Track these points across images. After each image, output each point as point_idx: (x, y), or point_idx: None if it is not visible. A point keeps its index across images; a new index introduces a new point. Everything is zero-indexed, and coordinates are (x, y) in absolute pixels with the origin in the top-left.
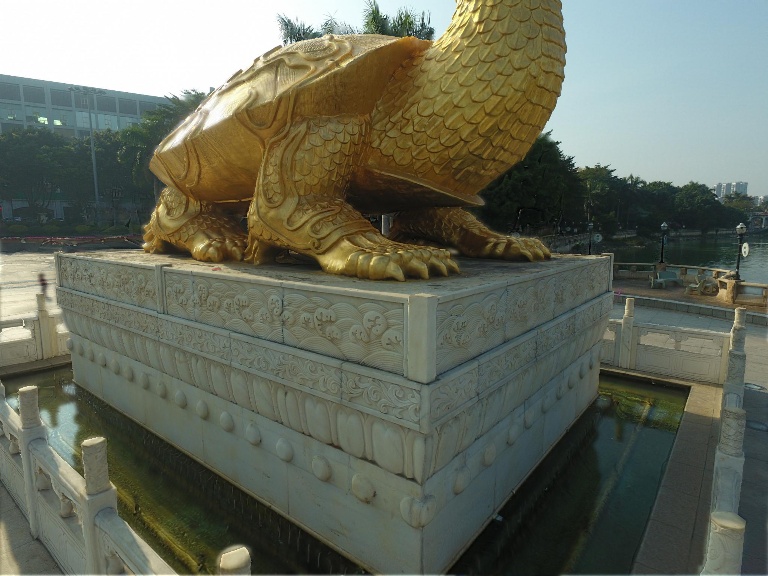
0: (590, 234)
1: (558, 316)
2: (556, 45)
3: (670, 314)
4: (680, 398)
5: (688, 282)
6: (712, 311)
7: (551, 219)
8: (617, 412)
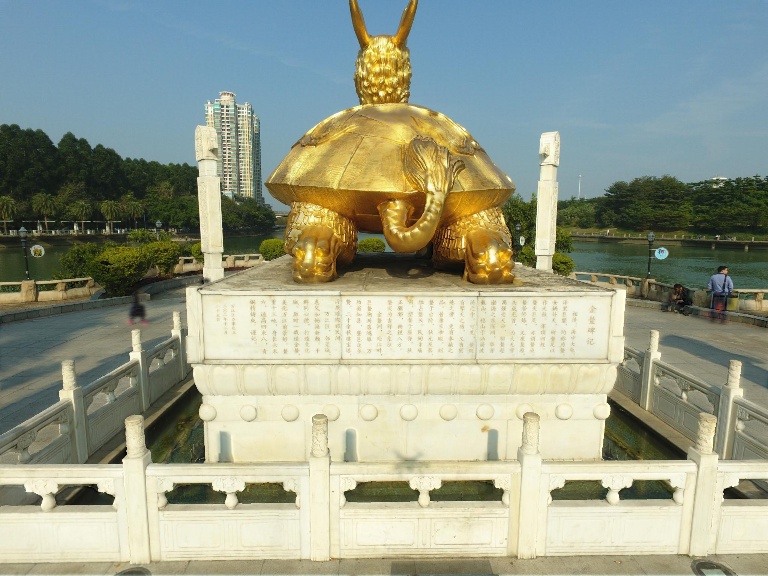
0: None
1: None
2: None
3: (16, 326)
4: None
5: None
6: (27, 314)
7: None
8: None
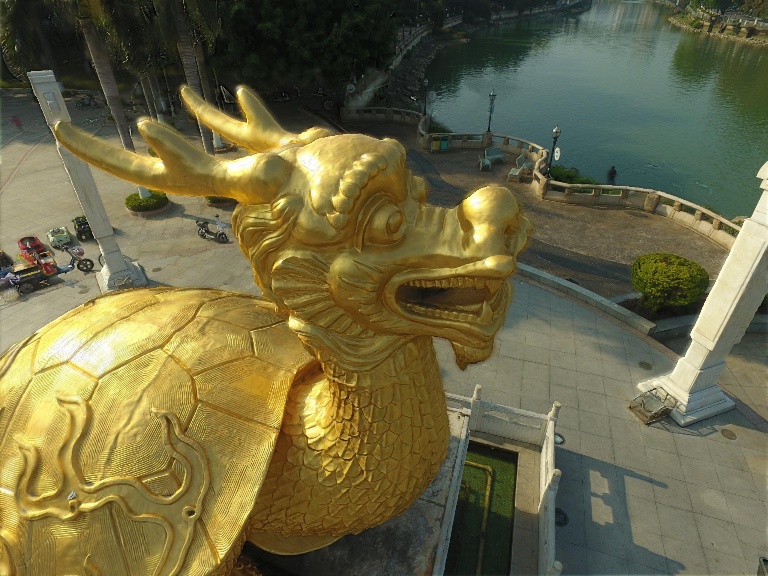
0: (425, 92)
1: (439, 574)
2: (443, 452)
3: None
4: (510, 459)
5: (509, 152)
6: (530, 274)
7: (386, 68)
8: (469, 500)
